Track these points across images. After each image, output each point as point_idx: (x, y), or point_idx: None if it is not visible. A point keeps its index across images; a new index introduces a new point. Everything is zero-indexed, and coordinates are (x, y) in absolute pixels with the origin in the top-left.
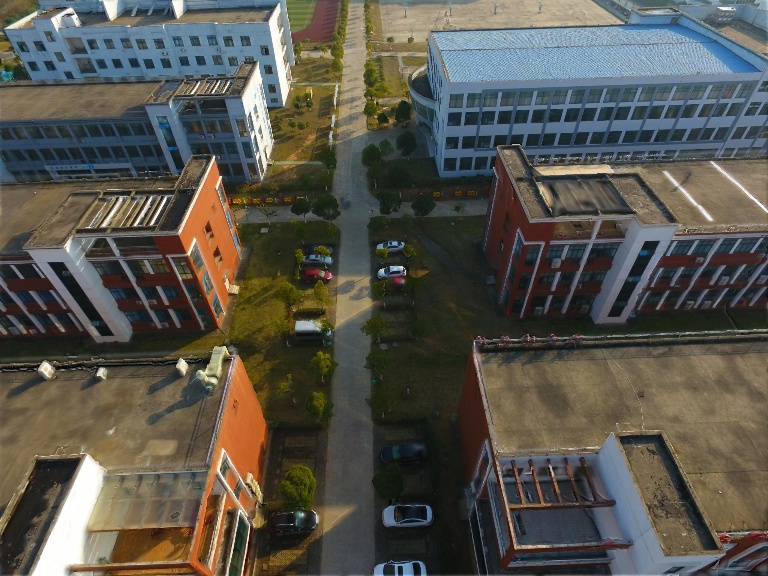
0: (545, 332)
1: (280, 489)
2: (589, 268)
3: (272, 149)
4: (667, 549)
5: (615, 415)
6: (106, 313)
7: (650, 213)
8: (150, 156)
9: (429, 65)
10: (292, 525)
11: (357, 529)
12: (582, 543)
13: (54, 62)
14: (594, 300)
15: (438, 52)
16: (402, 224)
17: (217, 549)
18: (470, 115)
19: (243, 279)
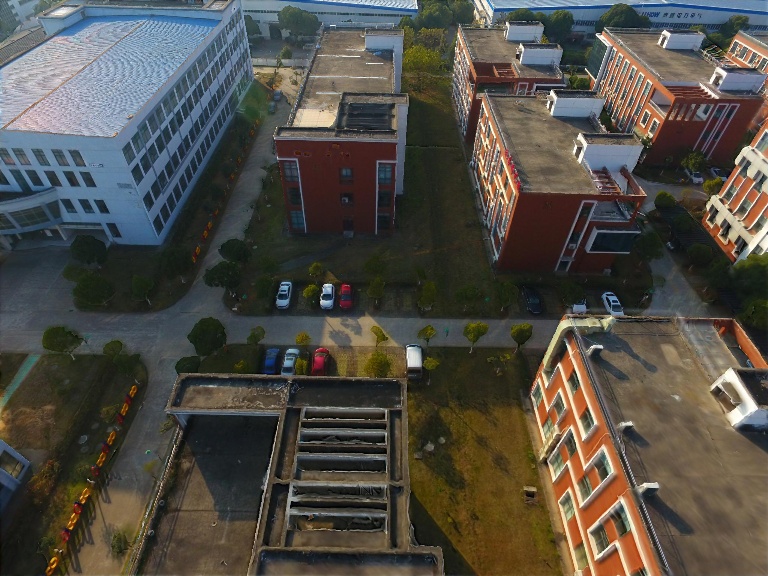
0: (409, 217)
1: None
2: None
3: None
4: None
5: (555, 156)
6: None
7: (392, 100)
8: None
9: None
10: None
11: None
12: None
13: None
14: None
15: (8, 130)
16: (271, 268)
17: None
18: (142, 161)
19: None
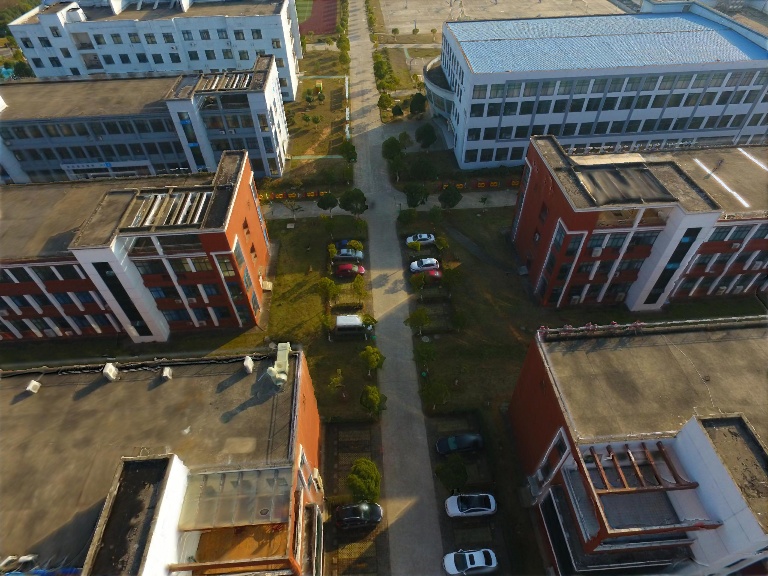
0: (583, 321)
1: (348, 483)
2: (628, 256)
3: (288, 144)
4: (765, 527)
5: (685, 399)
6: (146, 313)
7: (692, 200)
8: (169, 153)
9: (444, 56)
10: (359, 518)
11: (421, 520)
12: (673, 525)
13: (60, 58)
14: (630, 288)
15: (458, 43)
16: (432, 217)
17: (301, 544)
18: (493, 106)
19: (275, 275)
